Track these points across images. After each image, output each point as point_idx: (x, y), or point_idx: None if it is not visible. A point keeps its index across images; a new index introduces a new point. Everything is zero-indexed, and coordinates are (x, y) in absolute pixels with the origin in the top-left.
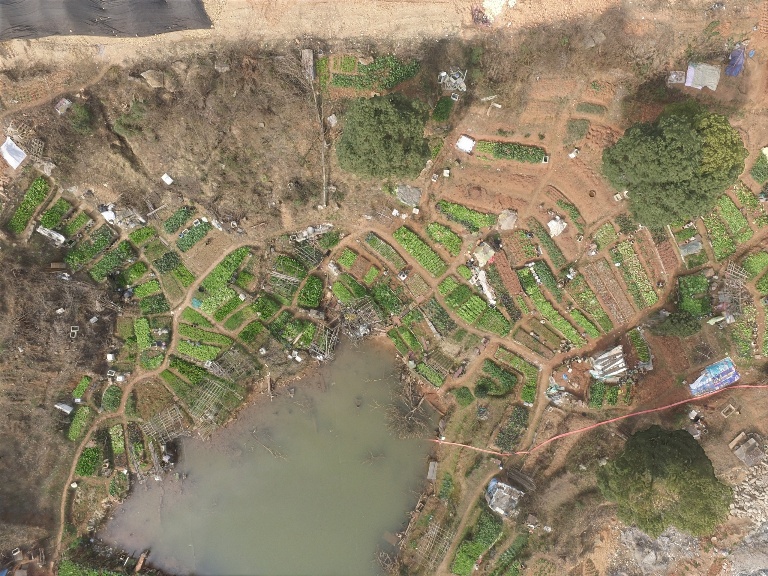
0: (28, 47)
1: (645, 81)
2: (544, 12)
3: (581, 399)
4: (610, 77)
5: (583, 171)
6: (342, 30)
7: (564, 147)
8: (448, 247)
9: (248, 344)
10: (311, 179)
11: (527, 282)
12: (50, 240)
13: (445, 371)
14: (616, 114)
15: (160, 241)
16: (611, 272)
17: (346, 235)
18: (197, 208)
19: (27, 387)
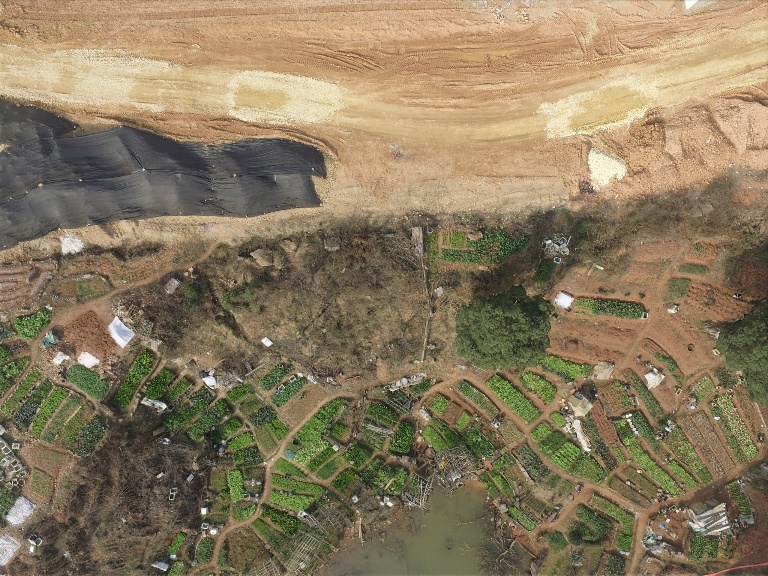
0: (136, 227)
1: (750, 247)
2: (652, 185)
3: (680, 550)
4: (713, 240)
5: (681, 325)
6: (450, 205)
7: (664, 304)
8: (542, 396)
9: (340, 491)
10: (411, 340)
11: (624, 433)
12: (152, 409)
13: (540, 520)
14: (717, 273)
15: (256, 397)
16: (710, 425)
17: (438, 381)
18: (294, 365)
19: (128, 553)
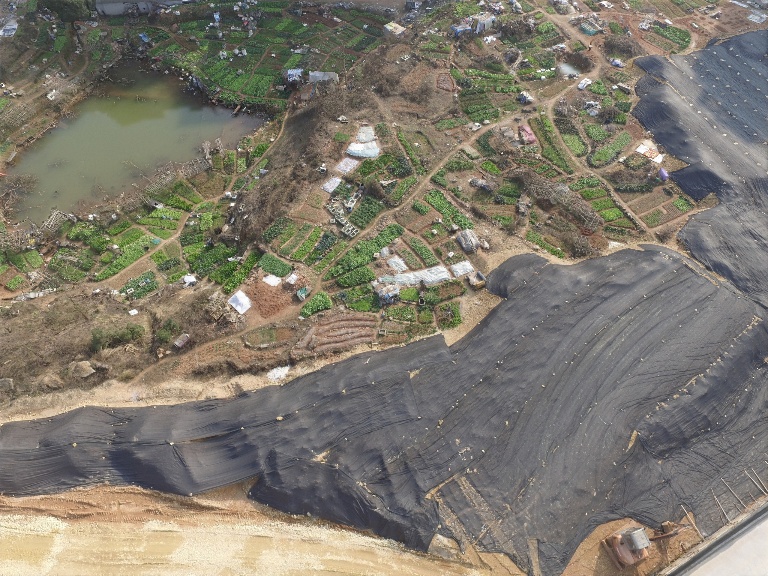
0: None
1: None
2: None
3: None
4: None
5: None
6: None
7: None
8: None
9: None
10: None
11: None
12: None
13: None
14: None
15: None
16: None
17: None
18: None
19: None
